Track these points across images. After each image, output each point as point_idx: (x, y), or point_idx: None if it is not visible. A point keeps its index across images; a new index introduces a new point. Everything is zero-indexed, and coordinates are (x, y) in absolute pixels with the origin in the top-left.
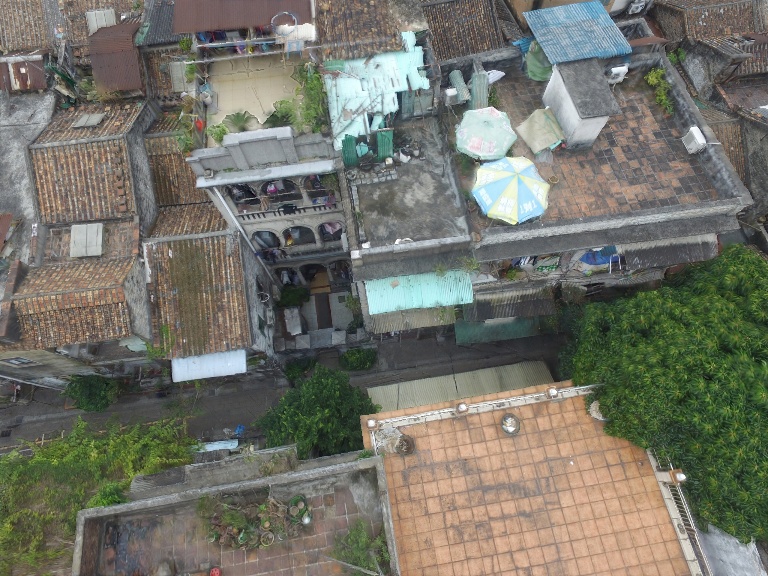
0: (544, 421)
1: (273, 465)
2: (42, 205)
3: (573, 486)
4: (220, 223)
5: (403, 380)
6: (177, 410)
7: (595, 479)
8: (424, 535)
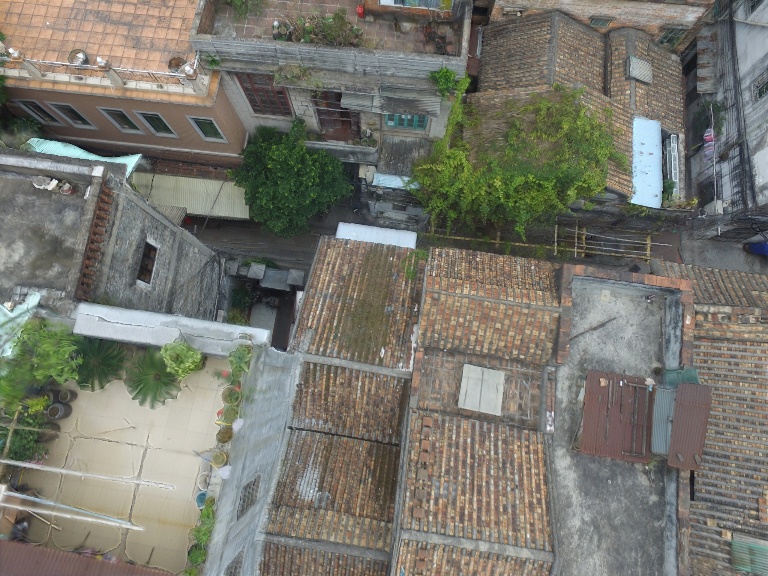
0: (50, 58)
1: (294, 70)
2: (541, 459)
3: (57, 8)
4: (314, 381)
5: (225, 241)
6: (437, 242)
7: (37, 9)
8: (193, 7)
